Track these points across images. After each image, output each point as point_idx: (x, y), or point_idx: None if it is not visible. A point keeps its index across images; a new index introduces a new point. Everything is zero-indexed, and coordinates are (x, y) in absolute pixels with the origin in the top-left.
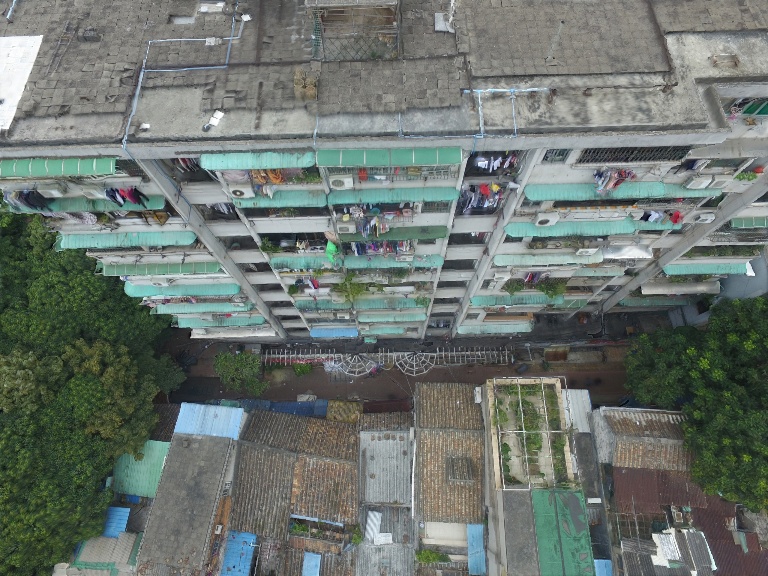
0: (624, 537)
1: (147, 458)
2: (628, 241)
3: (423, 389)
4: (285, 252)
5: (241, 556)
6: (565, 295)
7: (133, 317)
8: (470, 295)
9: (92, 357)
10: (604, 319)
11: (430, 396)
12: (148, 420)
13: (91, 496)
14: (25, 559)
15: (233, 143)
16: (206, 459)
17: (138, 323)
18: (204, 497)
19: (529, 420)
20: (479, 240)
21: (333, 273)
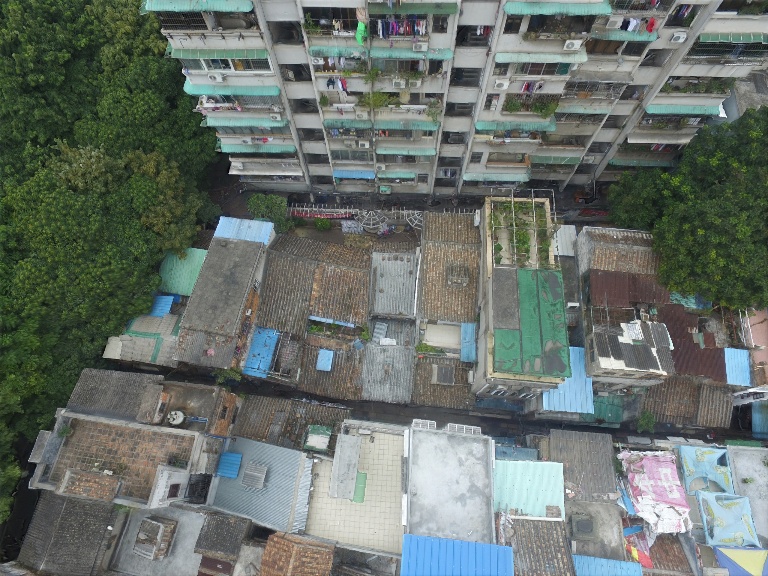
0: (596, 323)
1: (189, 263)
2: (612, 62)
3: (430, 216)
4: (322, 39)
5: (265, 344)
6: (560, 150)
7: (182, 144)
8: (475, 119)
9: (149, 161)
10: (596, 185)
11: (435, 221)
12: (191, 229)
13: (145, 271)
14: (89, 312)
15: None
16: (240, 256)
17: (186, 150)
18: (238, 283)
19: (520, 226)
20: (484, 45)
21: (359, 74)
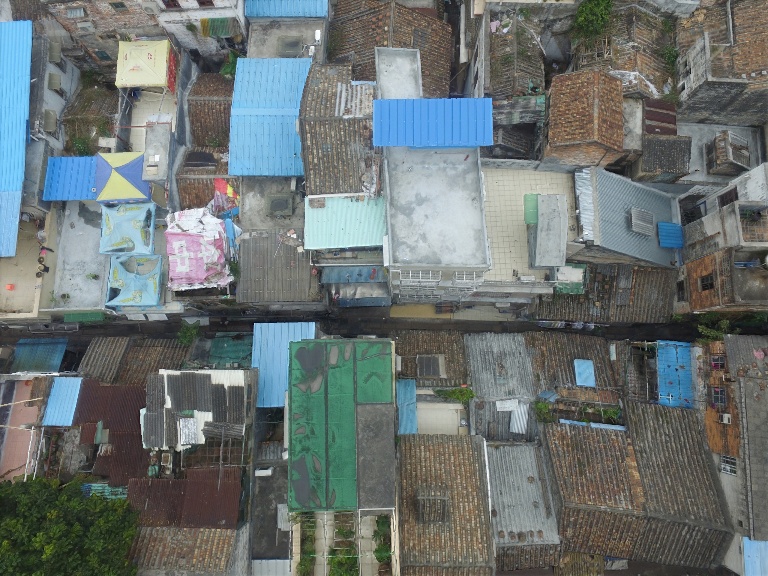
0: None
1: None
2: None
3: None
4: None
5: None
6: None
7: None
8: None
9: None
10: None
11: None
12: None
13: None
14: None
15: None
16: None
17: None
18: (766, 461)
19: None
20: None
21: None
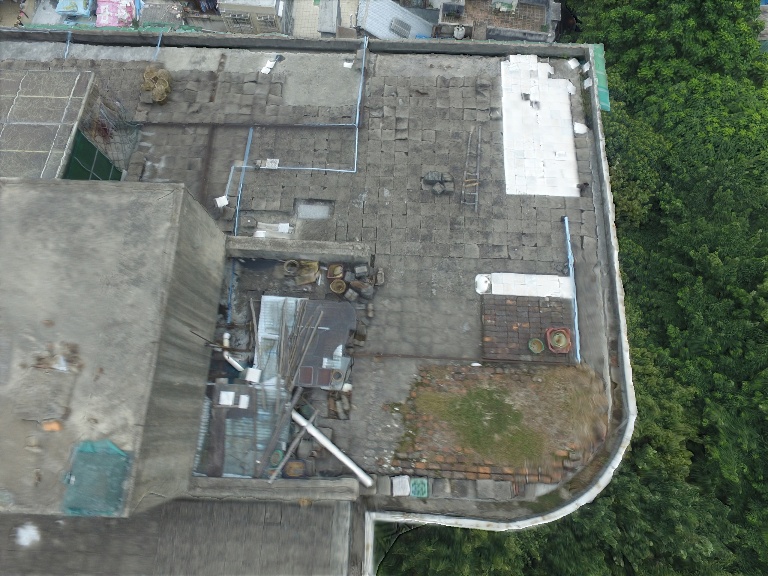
0: None
1: None
2: None
3: None
4: None
5: None
6: None
7: None
8: None
9: None
10: None
11: None
12: None
13: None
14: None
15: (249, 35)
16: None
17: None
18: None
19: None
20: None
21: None
